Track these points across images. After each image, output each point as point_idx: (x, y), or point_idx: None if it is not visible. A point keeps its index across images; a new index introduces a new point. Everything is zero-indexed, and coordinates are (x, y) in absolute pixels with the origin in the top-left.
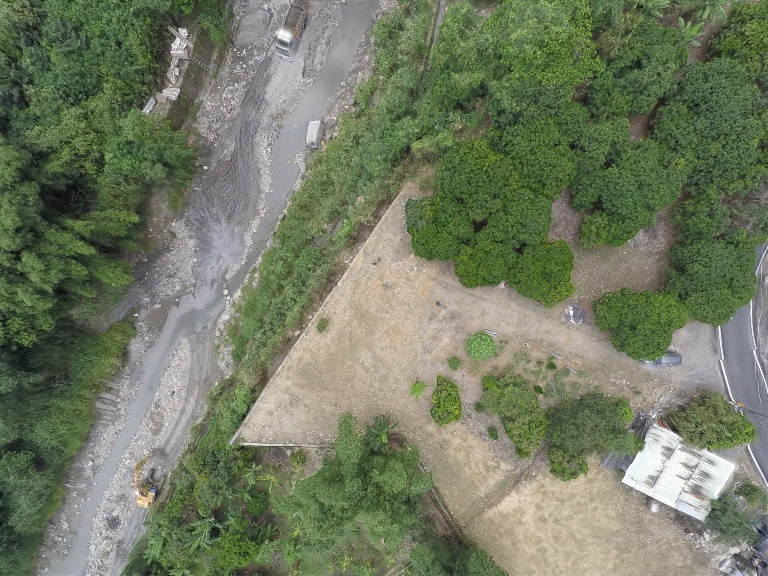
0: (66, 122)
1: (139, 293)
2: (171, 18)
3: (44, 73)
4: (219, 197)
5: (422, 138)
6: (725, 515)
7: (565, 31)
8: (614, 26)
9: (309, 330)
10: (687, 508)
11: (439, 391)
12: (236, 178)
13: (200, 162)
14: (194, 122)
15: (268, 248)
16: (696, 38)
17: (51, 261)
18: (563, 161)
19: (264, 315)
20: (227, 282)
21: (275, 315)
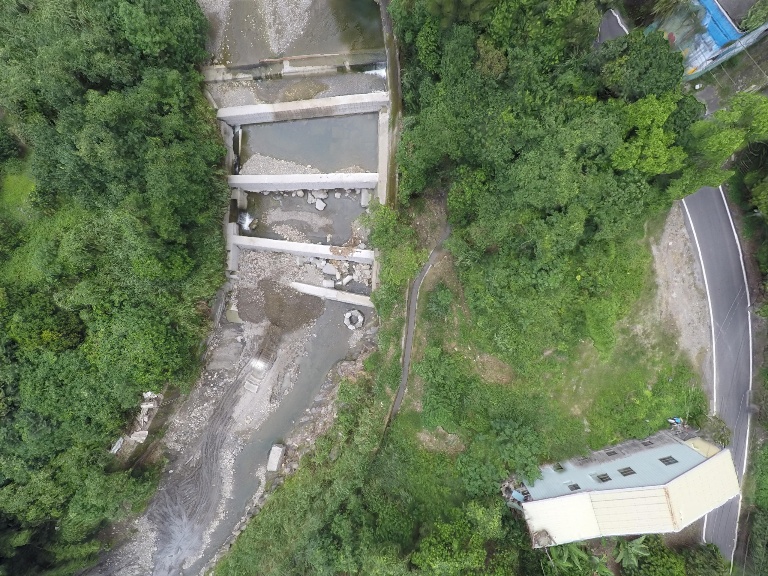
0: (34, 481)
1: None
2: None
3: (15, 448)
4: (182, 497)
5: (360, 572)
6: None
7: None
8: None
9: None
10: None
11: None
12: (199, 483)
13: (166, 468)
14: (162, 437)
15: (224, 552)
16: None
17: None
18: None
19: None
20: (184, 570)
21: None
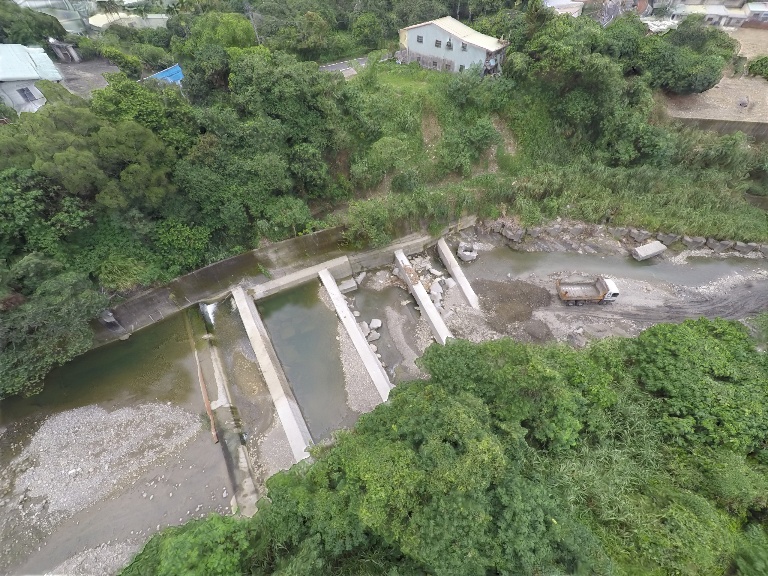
0: None
1: None
2: None
3: None
4: None
5: None
6: (664, 14)
7: None
8: None
9: None
10: None
11: (766, 69)
12: None
13: None
14: None
15: None
16: None
17: None
18: None
19: None
20: None
21: None
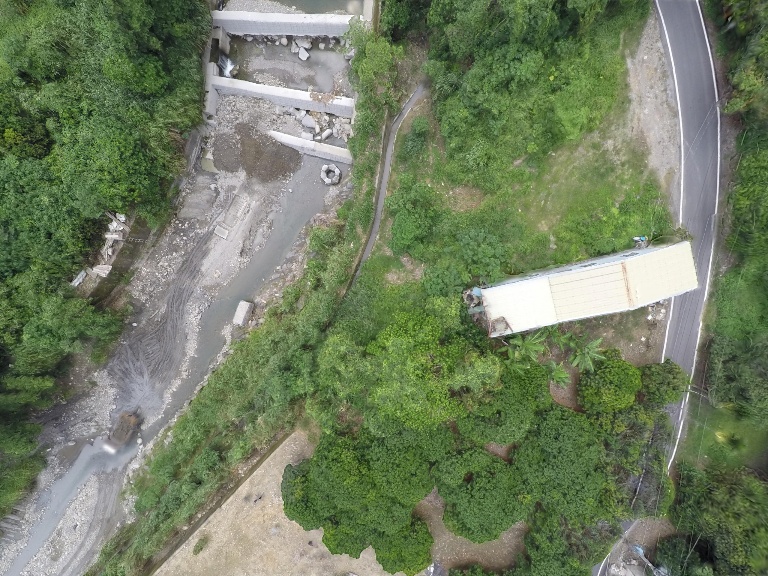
0: None
1: (54, 432)
2: None
3: None
4: (145, 353)
5: (317, 393)
6: None
7: (421, 406)
8: (474, 392)
9: (189, 543)
10: None
11: None
12: (163, 338)
13: (130, 320)
14: (127, 285)
15: (184, 410)
16: (564, 381)
17: None
18: (416, 490)
19: (165, 487)
20: (142, 431)
21: (170, 500)
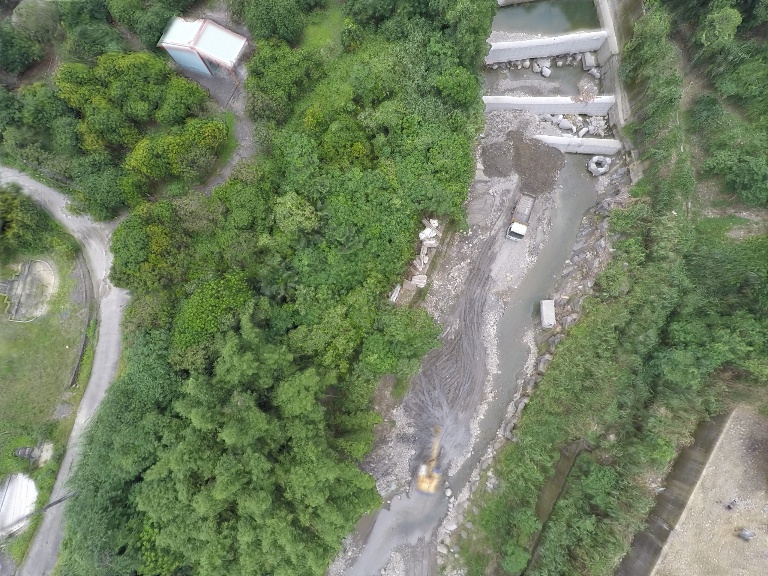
0: (328, 320)
1: None
2: (430, 213)
3: (317, 273)
4: (442, 378)
5: (751, 354)
6: None
7: None
8: None
9: None
10: None
11: None
12: (460, 358)
13: None
14: (422, 301)
15: (502, 440)
16: None
17: (342, 507)
18: None
19: (528, 539)
20: (449, 479)
21: (559, 548)
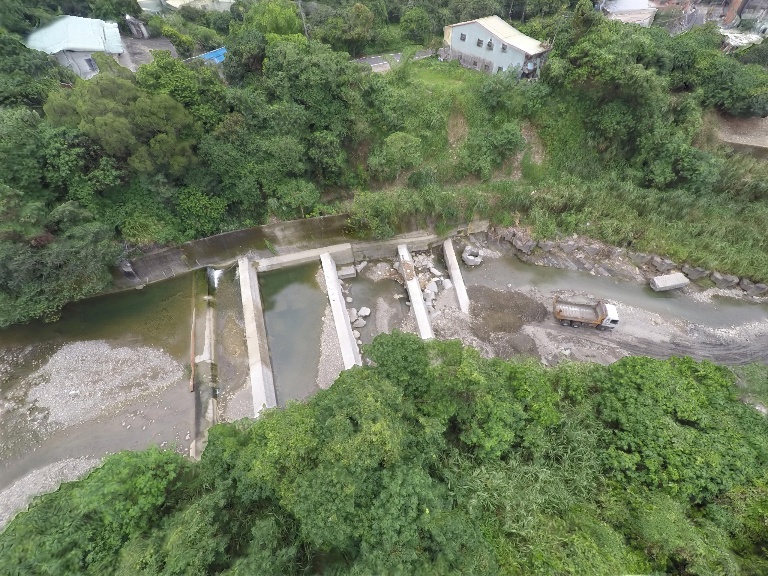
0: None
1: None
2: None
3: None
4: None
5: None
6: (752, 26)
7: None
8: None
9: None
10: (760, 38)
11: None
12: None
13: None
14: None
15: None
16: None
17: None
18: None
19: None
20: None
21: None
